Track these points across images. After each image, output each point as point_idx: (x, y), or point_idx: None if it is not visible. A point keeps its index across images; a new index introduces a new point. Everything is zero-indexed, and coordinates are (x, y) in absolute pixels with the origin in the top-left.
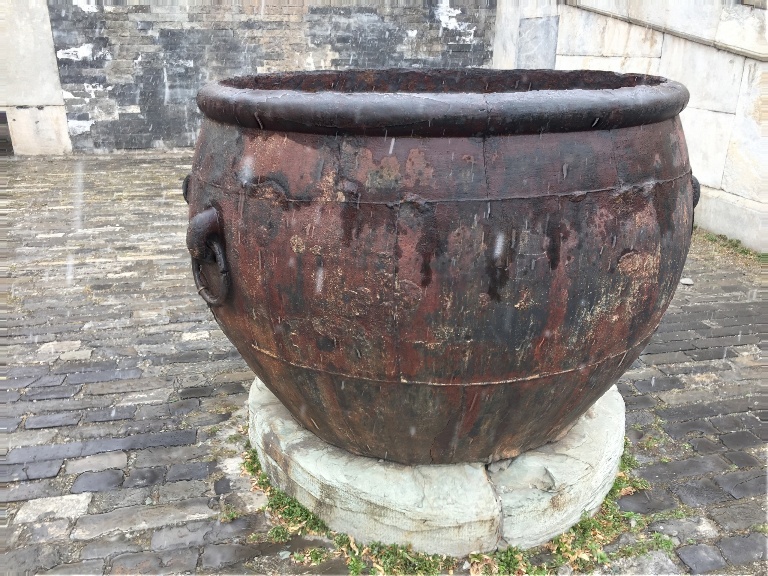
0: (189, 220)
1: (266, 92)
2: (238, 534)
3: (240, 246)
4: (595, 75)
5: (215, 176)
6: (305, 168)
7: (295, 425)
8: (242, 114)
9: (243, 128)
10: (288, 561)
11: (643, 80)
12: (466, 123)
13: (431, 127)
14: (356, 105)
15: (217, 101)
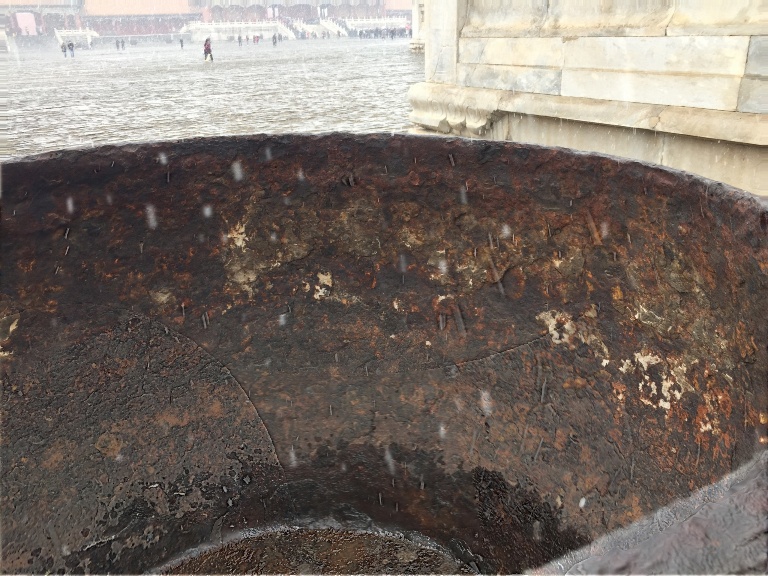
0: None
1: None
2: None
3: None
4: None
5: None
6: None
7: None
8: None
9: None
10: None
11: None
12: None
13: None
14: (307, 145)
15: None
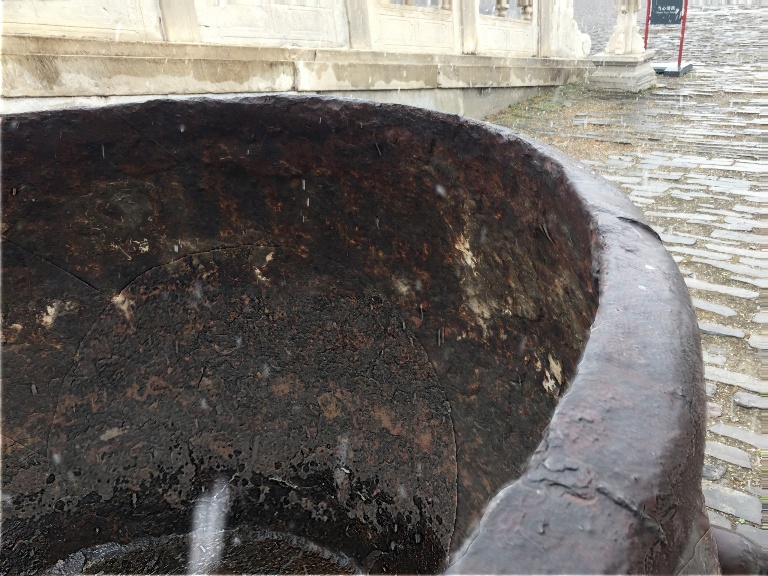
0: None
1: (600, 182)
2: None
3: None
4: None
5: None
6: None
7: None
8: None
9: None
10: None
11: None
12: None
13: None
14: (496, 150)
15: None
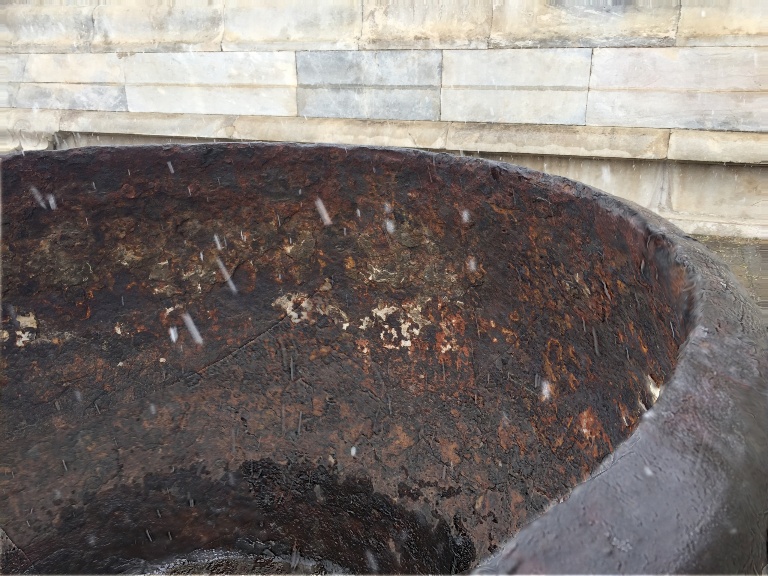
0: None
1: None
2: None
3: None
4: None
5: None
6: None
7: None
8: None
9: None
10: None
11: None
12: None
13: None
14: None
15: None
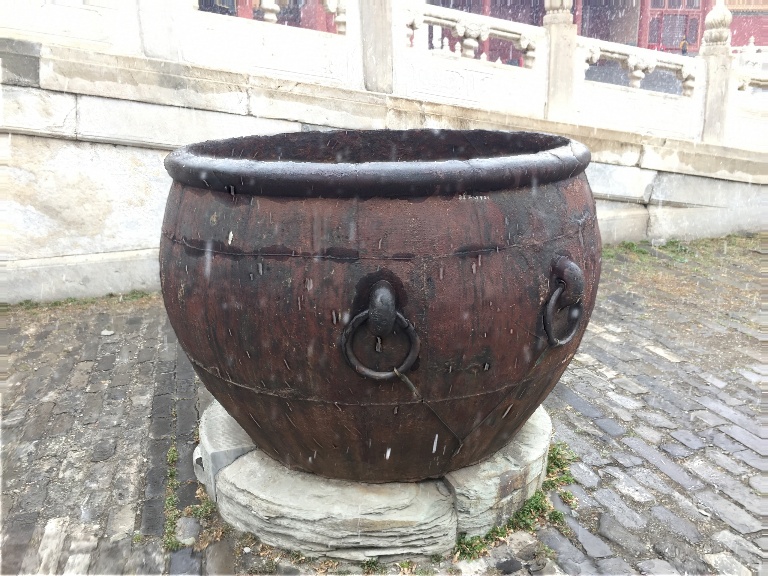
0: (514, 297)
1: (564, 150)
2: (567, 542)
3: (585, 271)
4: (299, 135)
5: (555, 230)
6: (589, 195)
7: (486, 463)
8: (569, 169)
9: (558, 182)
10: (579, 512)
11: (358, 133)
12: (575, 151)
13: (580, 155)
14: None
15: (547, 165)
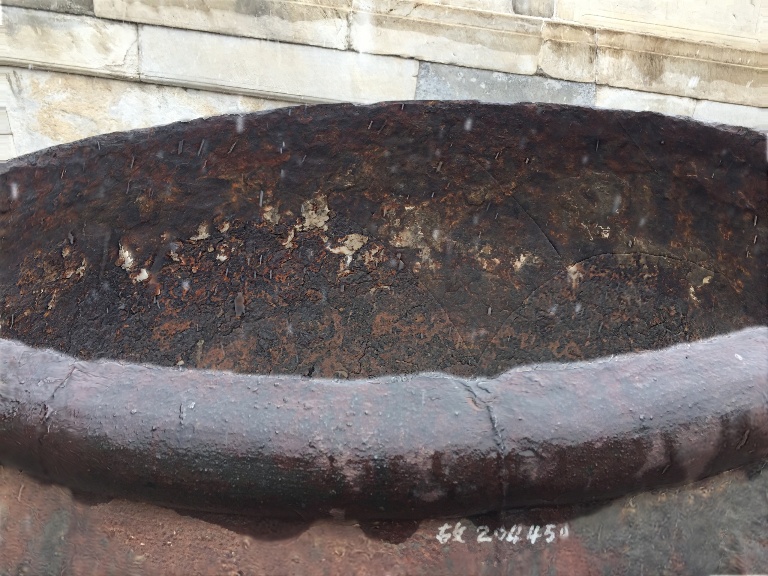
0: None
1: None
2: None
3: None
4: (316, 111)
5: None
6: None
7: None
8: None
9: None
10: None
11: (424, 107)
12: None
13: None
14: None
15: None
